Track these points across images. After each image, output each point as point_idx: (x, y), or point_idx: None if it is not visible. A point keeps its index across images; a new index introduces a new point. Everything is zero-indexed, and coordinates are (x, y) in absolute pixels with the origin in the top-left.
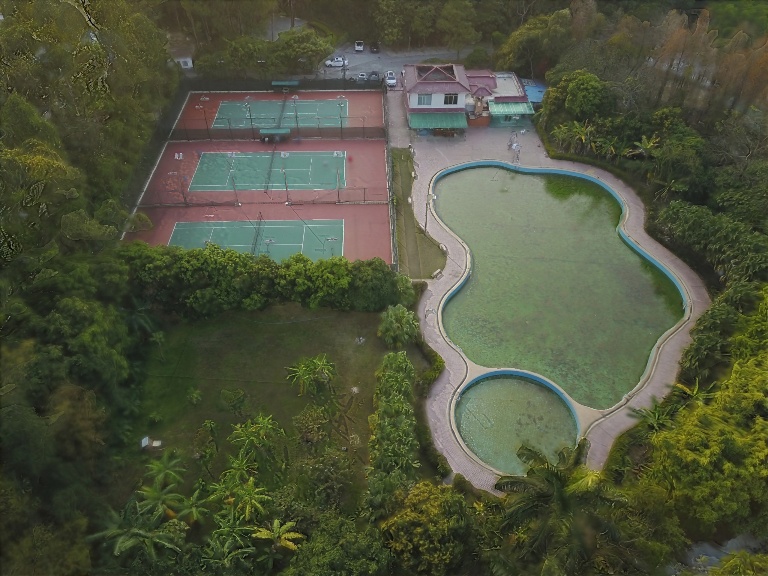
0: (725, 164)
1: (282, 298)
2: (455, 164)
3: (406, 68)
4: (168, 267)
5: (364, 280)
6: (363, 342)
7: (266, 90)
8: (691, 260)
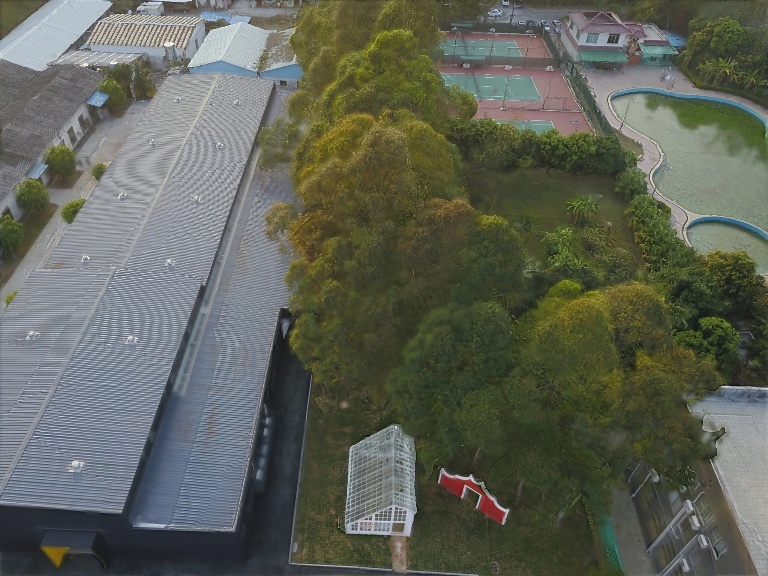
0: None
1: (538, 163)
2: (622, 89)
3: (572, 14)
4: (469, 130)
5: (607, 148)
6: (602, 197)
7: (444, 30)
8: None
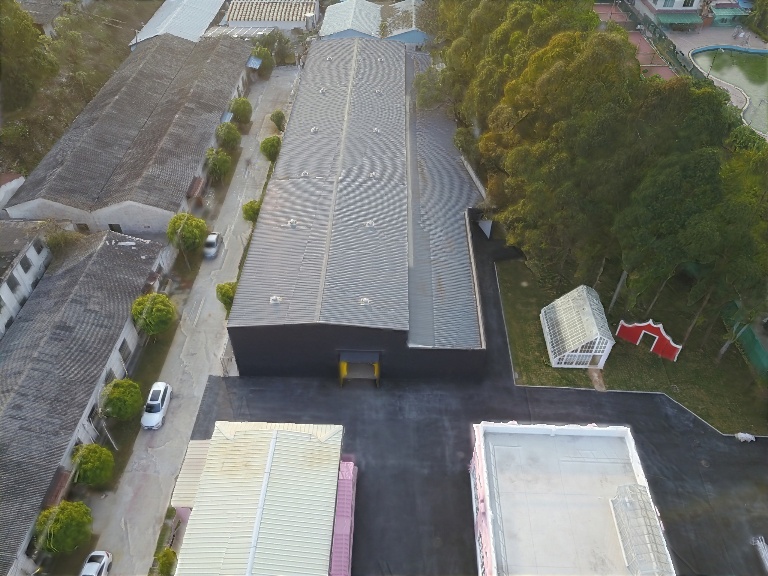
0: None
1: None
2: (700, 46)
3: None
4: None
5: None
6: None
7: None
8: None
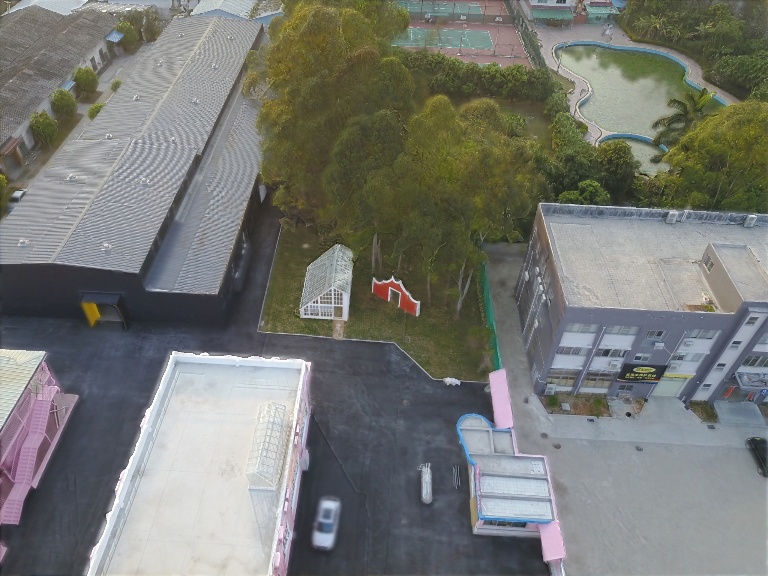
0: (758, 38)
1: (481, 91)
2: None
3: None
4: (421, 60)
5: (537, 78)
6: (533, 118)
7: None
8: (735, 92)
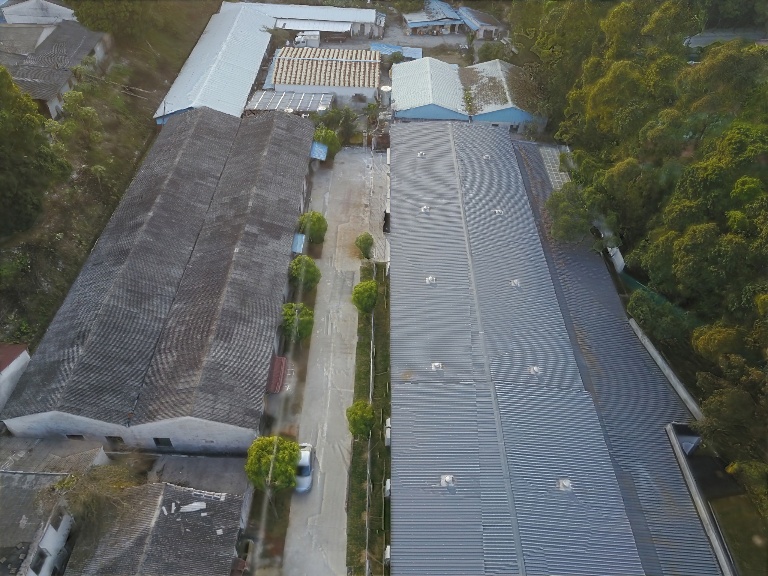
0: None
1: None
2: None
3: (761, 43)
4: None
5: None
6: None
7: None
8: None
